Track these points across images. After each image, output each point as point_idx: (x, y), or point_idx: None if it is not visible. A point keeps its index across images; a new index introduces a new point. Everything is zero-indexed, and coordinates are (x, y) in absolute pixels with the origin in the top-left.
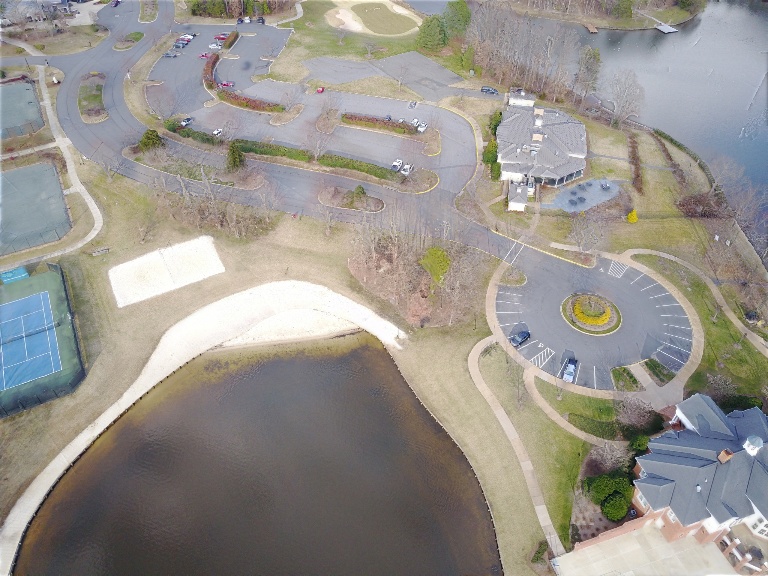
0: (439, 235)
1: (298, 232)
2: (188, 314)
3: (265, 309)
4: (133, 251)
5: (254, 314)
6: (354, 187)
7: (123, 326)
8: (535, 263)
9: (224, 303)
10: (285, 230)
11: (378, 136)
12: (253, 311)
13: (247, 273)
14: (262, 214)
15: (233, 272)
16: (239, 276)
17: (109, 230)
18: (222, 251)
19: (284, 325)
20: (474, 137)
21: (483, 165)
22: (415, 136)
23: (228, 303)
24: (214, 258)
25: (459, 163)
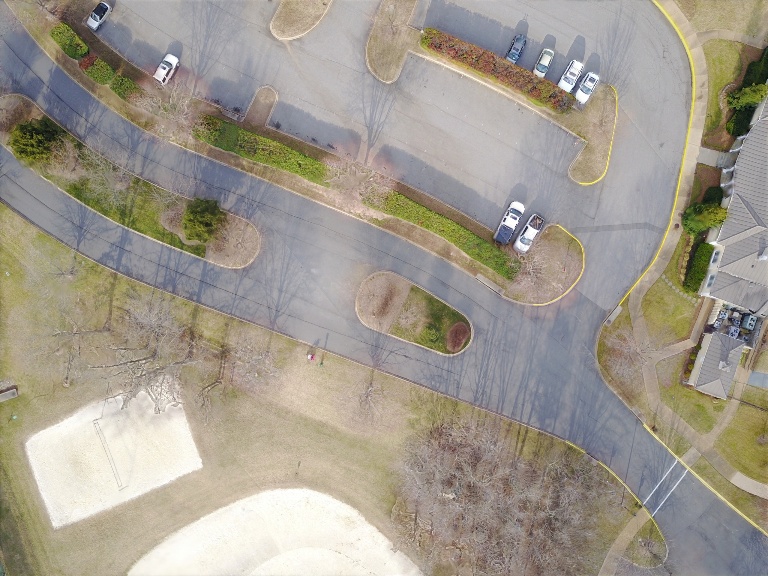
0: (552, 428)
1: (317, 390)
2: (155, 544)
3: (265, 543)
4: (55, 402)
5: (249, 552)
6: (423, 275)
7: (66, 564)
8: (692, 518)
9: (205, 527)
10: (296, 383)
11: (490, 103)
12: (248, 546)
13: (236, 470)
14: (257, 343)
15: (215, 469)
16: (224, 476)
17: (8, 344)
18: (195, 418)
19: (292, 575)
20: (687, 126)
21: (679, 231)
22: (565, 115)
23: (211, 527)
24: (183, 434)
25: (634, 217)
